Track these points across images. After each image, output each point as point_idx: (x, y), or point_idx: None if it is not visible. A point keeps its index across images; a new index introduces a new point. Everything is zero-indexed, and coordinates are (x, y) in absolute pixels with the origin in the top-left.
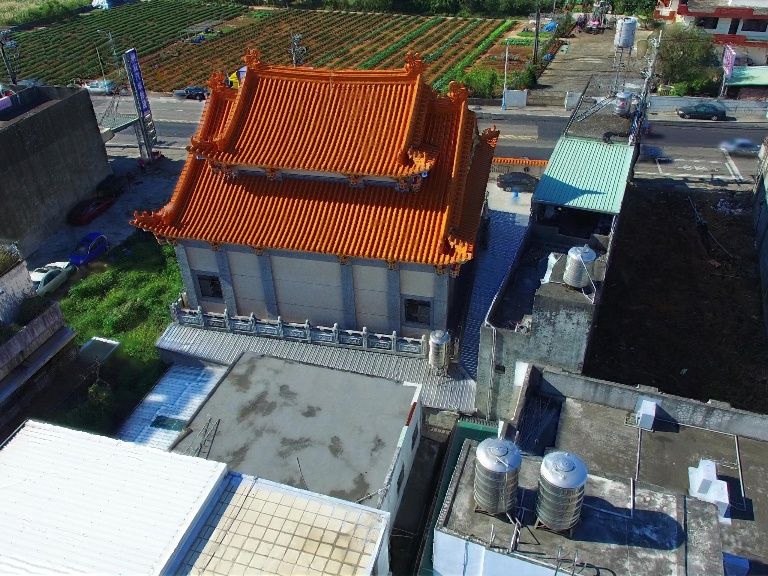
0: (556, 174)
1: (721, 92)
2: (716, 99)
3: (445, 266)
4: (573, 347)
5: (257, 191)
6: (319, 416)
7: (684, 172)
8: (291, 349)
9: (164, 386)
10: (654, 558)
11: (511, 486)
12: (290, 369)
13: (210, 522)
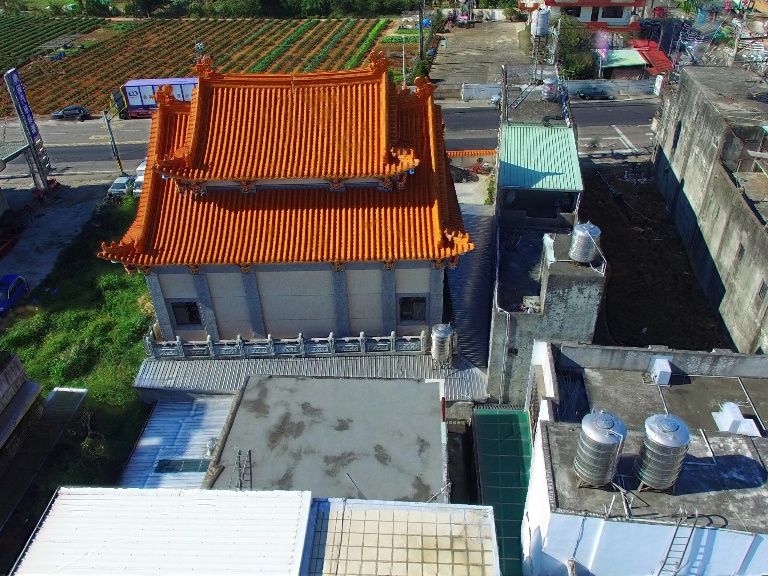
0: (513, 160)
1: (599, 74)
2: (610, 80)
3: (443, 259)
4: (584, 320)
5: (232, 206)
6: (353, 428)
7: (587, 150)
8: (286, 366)
9: (155, 428)
10: (750, 497)
11: (619, 456)
12: (305, 386)
13: (316, 554)
